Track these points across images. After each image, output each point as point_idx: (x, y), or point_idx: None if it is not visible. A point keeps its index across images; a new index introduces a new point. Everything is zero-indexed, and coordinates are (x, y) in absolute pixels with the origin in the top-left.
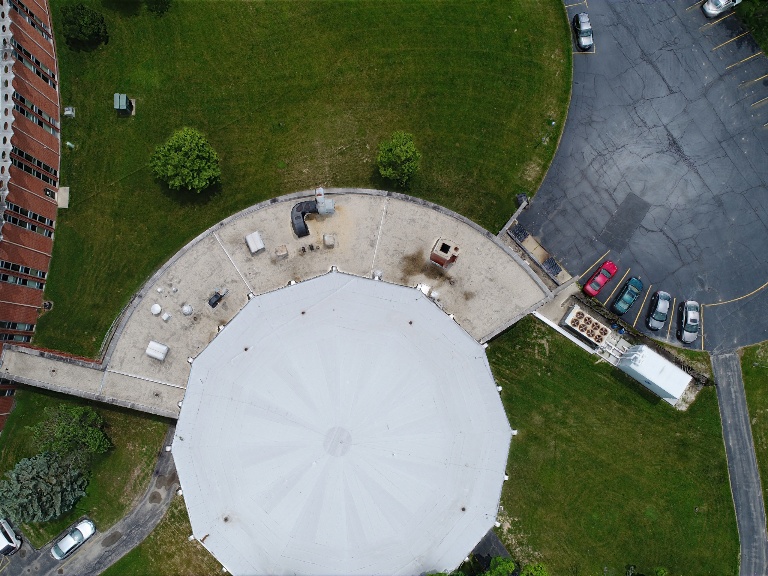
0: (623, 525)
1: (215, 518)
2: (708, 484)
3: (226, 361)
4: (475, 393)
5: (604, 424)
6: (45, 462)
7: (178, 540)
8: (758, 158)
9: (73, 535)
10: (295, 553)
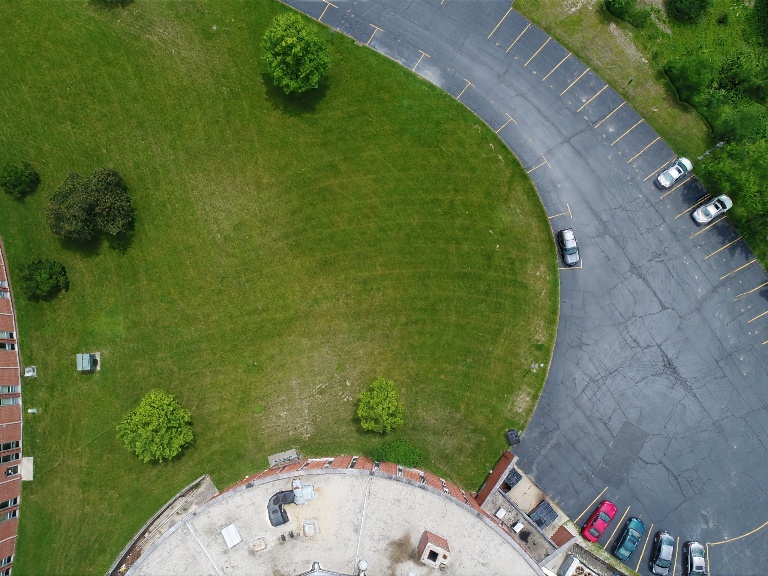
0: None
1: None
2: None
3: None
4: None
5: None
6: None
7: None
8: (758, 377)
9: None
10: None
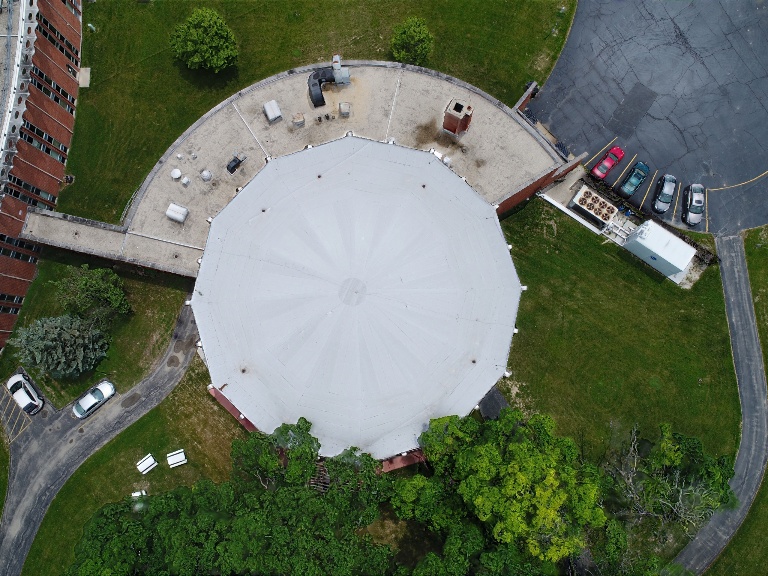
0: (628, 393)
1: (233, 369)
2: (711, 357)
3: (244, 222)
4: (486, 252)
5: (610, 299)
6: (68, 318)
7: (195, 402)
8: (763, 50)
9: (94, 394)
10: (310, 402)
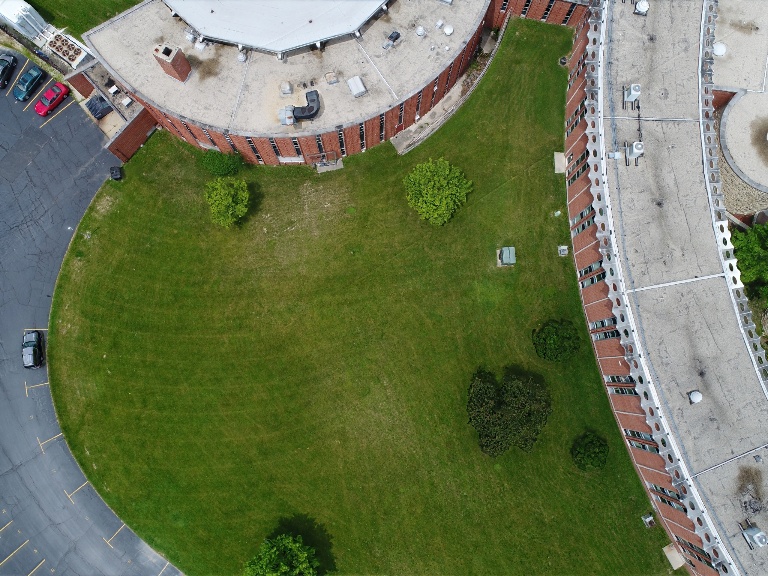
0: None
1: None
2: None
3: None
4: None
5: None
6: None
7: None
8: None
9: None
10: None
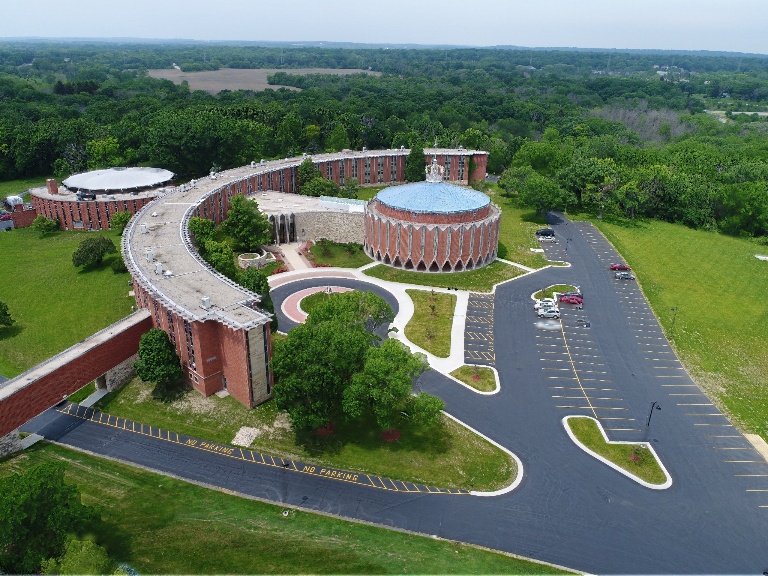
0: None
1: None
2: None
3: None
4: None
5: None
6: None
7: None
8: None
9: None
10: None
